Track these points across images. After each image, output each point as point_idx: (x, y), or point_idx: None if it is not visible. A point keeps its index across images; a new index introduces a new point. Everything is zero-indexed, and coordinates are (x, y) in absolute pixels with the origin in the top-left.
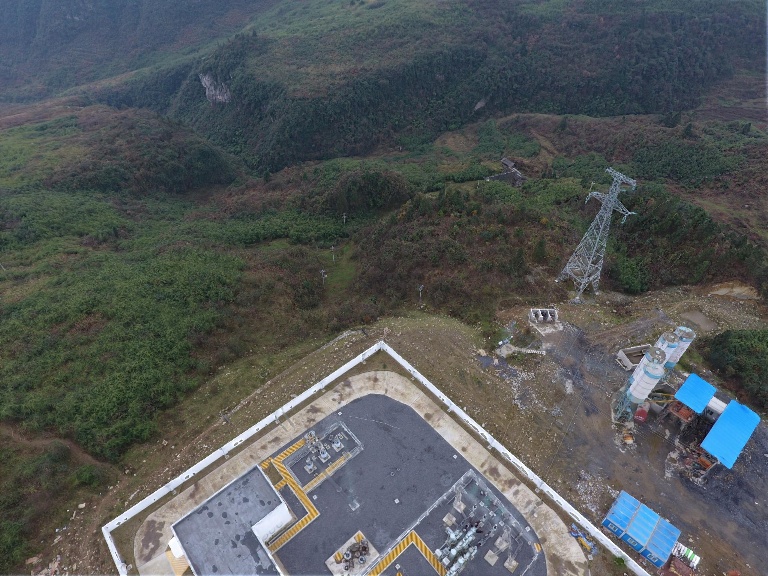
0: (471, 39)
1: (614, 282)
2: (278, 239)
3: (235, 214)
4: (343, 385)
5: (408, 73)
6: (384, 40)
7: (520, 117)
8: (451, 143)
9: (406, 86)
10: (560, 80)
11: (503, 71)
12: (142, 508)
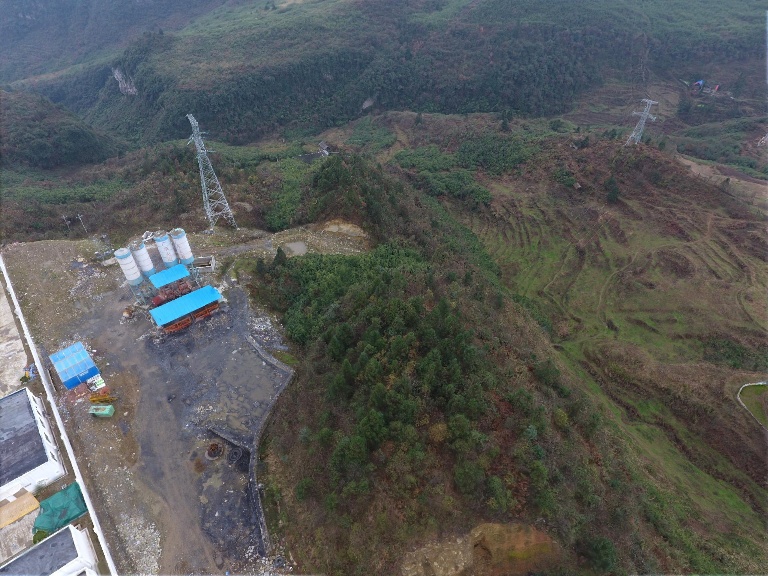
0: (359, 43)
1: (261, 222)
2: (87, 202)
3: (71, 184)
4: None
5: (294, 71)
6: (275, 41)
7: (389, 114)
8: (330, 137)
9: (293, 83)
10: (440, 83)
11: (387, 73)
12: None
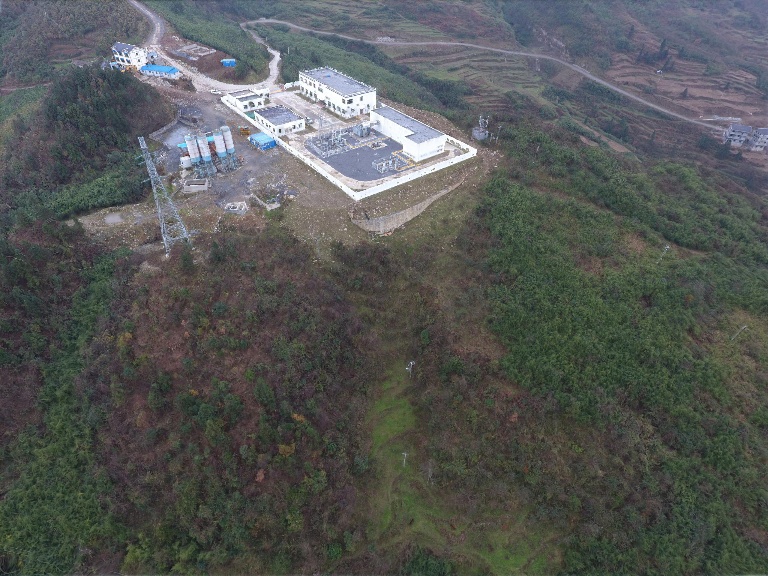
0: None
1: None
2: None
3: None
4: None
5: None
6: None
7: None
8: None
9: None
10: None
11: None
12: (466, 157)
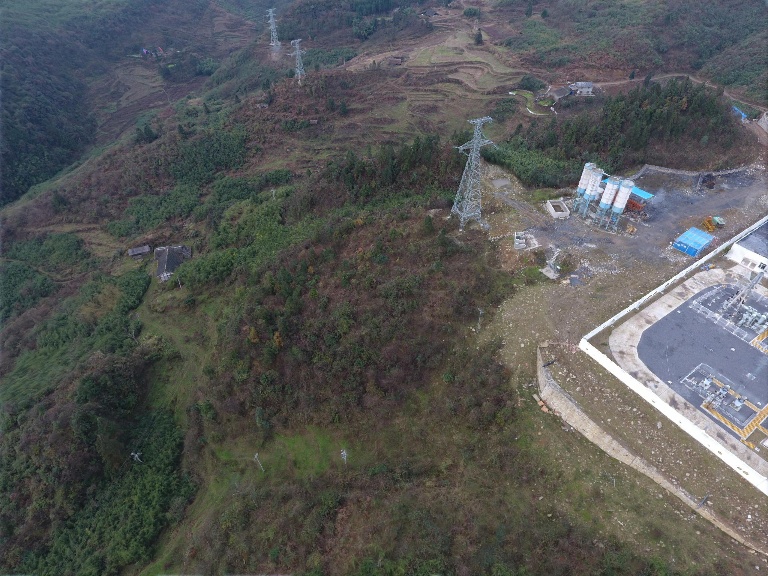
0: None
1: None
2: None
3: None
4: (636, 378)
5: None
6: None
7: None
8: None
9: None
10: None
11: None
12: None
